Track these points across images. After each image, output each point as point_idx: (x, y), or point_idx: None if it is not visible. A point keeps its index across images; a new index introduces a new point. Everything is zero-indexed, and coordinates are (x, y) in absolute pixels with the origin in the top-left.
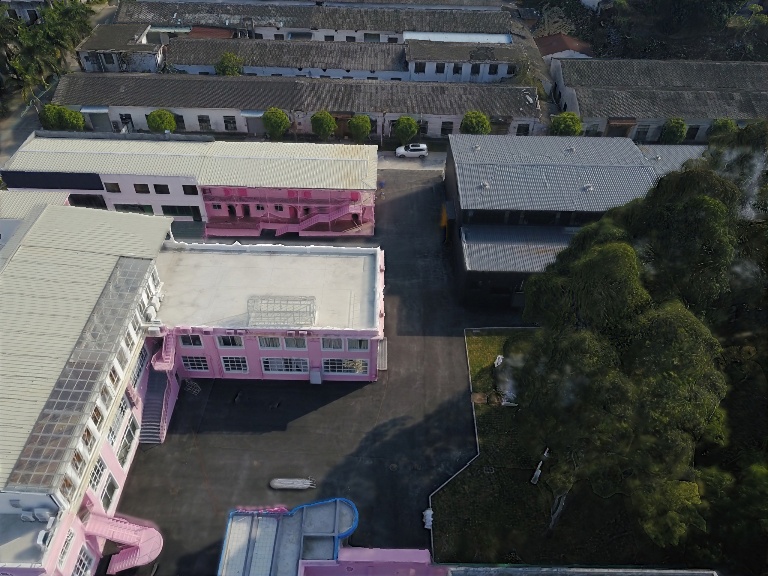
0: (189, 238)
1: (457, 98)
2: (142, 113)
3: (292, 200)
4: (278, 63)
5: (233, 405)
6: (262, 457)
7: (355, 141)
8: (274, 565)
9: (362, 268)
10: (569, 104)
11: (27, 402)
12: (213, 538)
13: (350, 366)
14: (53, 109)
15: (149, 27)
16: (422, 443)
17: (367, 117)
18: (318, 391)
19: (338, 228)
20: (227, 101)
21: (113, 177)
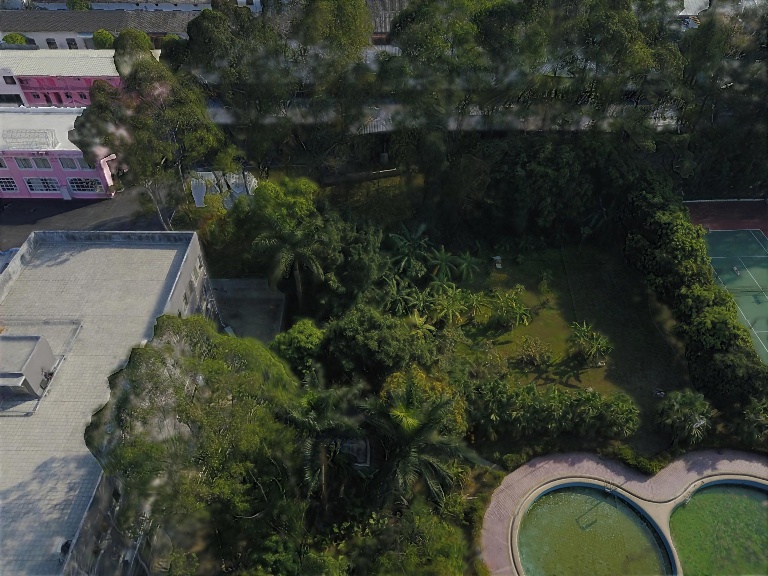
0: None
1: None
2: (2, 38)
3: None
4: None
5: (3, 211)
6: (11, 237)
7: None
8: None
9: None
10: None
11: None
12: None
13: (90, 185)
14: None
15: None
16: None
17: (176, 36)
18: (68, 204)
19: None
20: (67, 26)
21: None
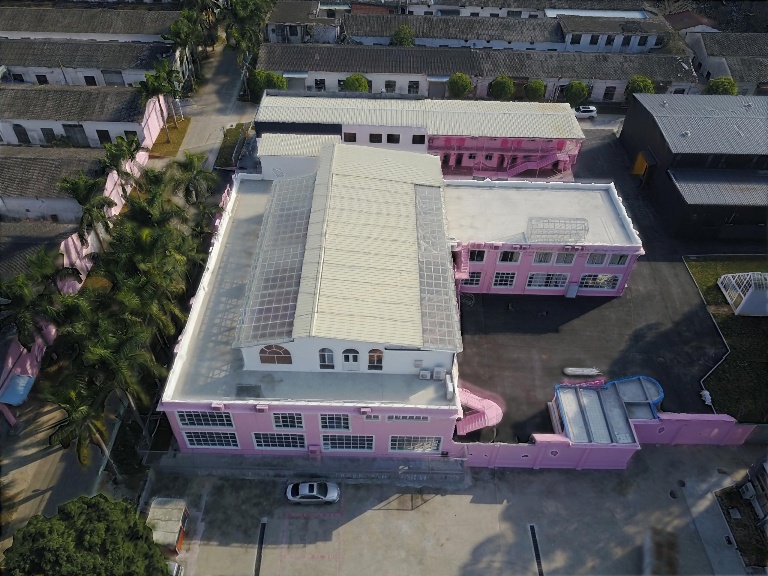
0: None
1: (619, 65)
2: (336, 78)
3: (505, 149)
4: (446, 35)
5: (507, 313)
6: (548, 352)
7: None
8: (609, 422)
9: (601, 200)
10: (715, 72)
11: (405, 288)
12: (533, 410)
13: (602, 282)
14: (262, 74)
15: (319, 3)
16: (678, 343)
17: (542, 82)
18: (573, 303)
19: (543, 175)
20: (413, 67)
21: (354, 127)
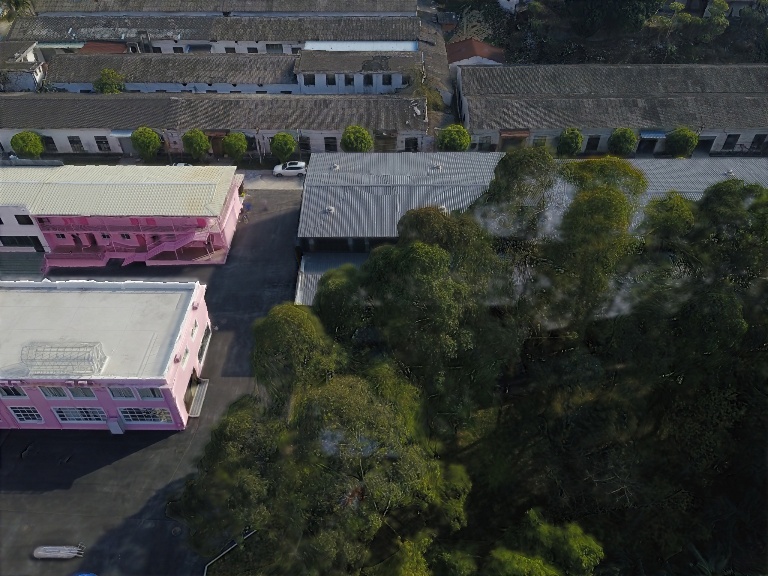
0: (28, 270)
1: (340, 112)
2: (10, 135)
3: (135, 228)
4: (161, 79)
5: (20, 460)
6: (35, 520)
7: None
8: None
9: (175, 305)
10: (465, 115)
11: None
12: None
13: (152, 415)
14: None
15: (35, 44)
16: None
17: (242, 134)
18: (119, 442)
19: (187, 256)
20: (97, 121)
21: None
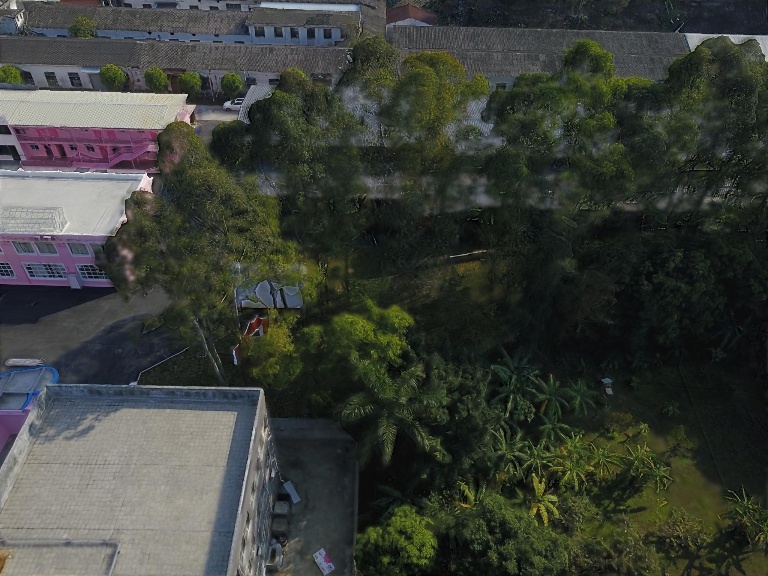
0: None
1: (283, 57)
2: None
3: (98, 140)
4: (129, 27)
5: None
6: (7, 343)
7: (191, 97)
8: None
9: (126, 190)
10: None
11: None
12: None
13: None
14: None
15: None
16: (151, 334)
17: (196, 73)
18: (77, 294)
19: (143, 167)
20: (70, 59)
21: None
